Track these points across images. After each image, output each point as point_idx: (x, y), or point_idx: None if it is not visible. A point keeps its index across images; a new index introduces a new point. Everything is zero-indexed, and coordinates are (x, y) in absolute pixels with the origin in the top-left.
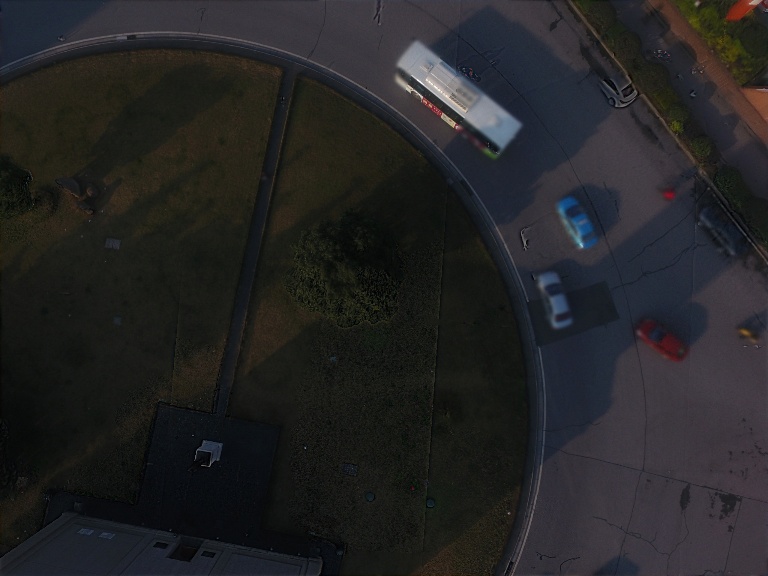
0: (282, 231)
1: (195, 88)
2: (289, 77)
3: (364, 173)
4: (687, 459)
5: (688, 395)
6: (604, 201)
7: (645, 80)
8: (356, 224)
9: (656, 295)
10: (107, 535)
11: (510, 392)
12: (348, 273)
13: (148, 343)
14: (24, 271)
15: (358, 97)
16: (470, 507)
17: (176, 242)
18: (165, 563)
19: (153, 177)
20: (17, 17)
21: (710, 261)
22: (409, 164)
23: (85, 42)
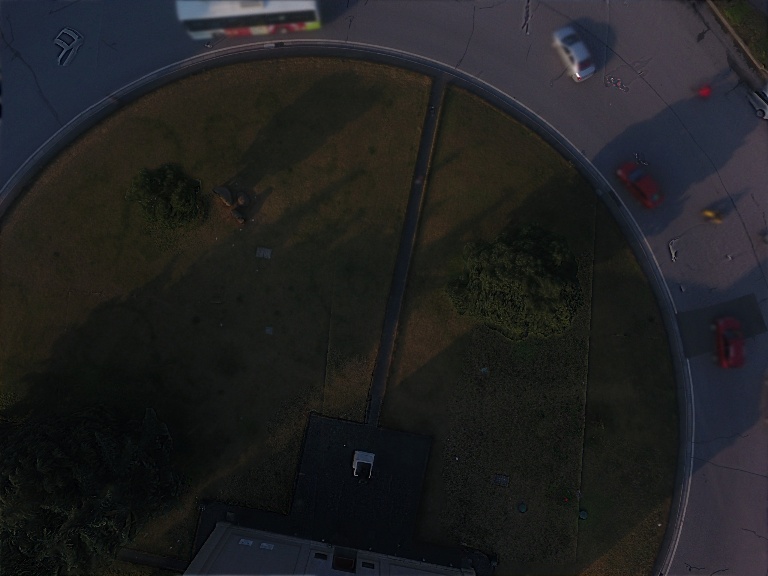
0: (433, 241)
1: (345, 97)
2: (438, 86)
3: (514, 183)
4: None
5: None
6: (752, 213)
7: None
8: (547, 238)
9: None
10: (267, 546)
11: (660, 404)
12: (554, 288)
13: (300, 353)
14: (175, 280)
15: (507, 107)
16: (622, 519)
17: (327, 252)
18: (334, 575)
19: (304, 186)
20: (163, 23)
21: None
22: (559, 175)
23: (233, 49)
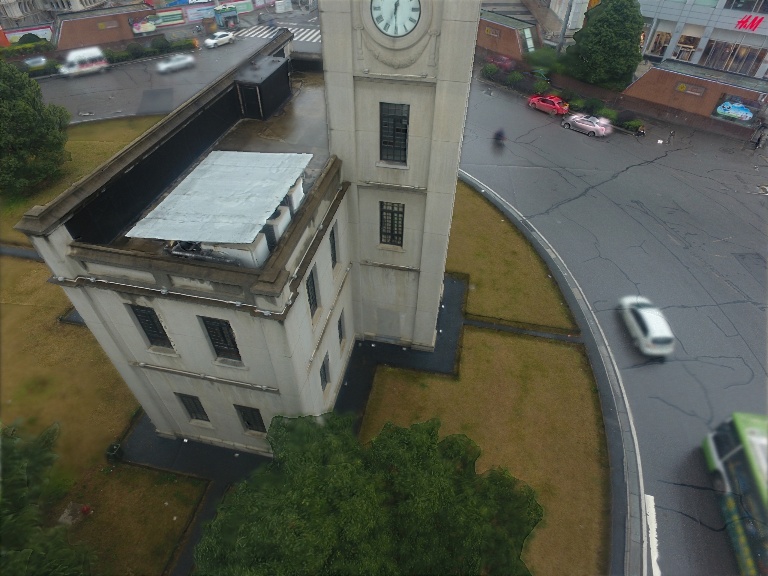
0: None
1: None
2: None
3: None
4: None
5: None
6: (88, 90)
7: None
8: None
9: None
10: None
11: None
12: None
13: None
14: None
15: None
16: None
17: None
18: None
19: None
20: None
21: None
22: None
23: None
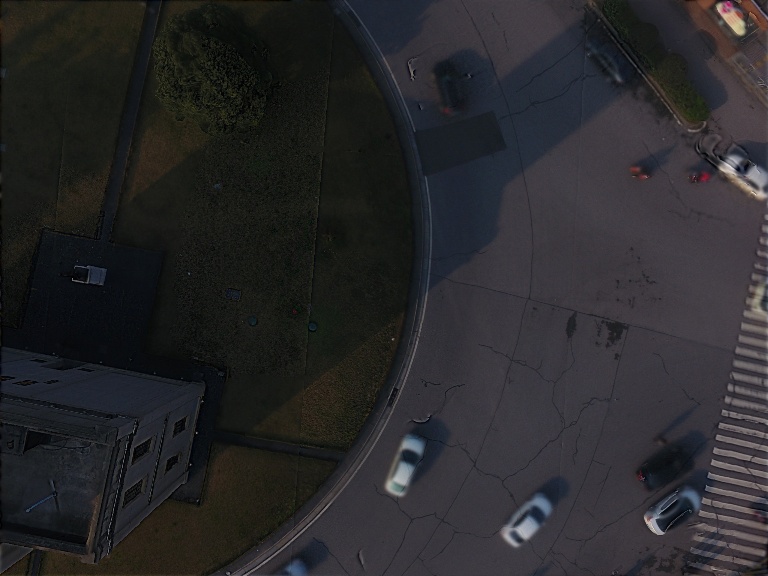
0: None
1: None
2: None
3: (250, 3)
4: (574, 287)
5: (576, 224)
6: (492, 32)
7: None
8: None
9: (544, 125)
10: None
11: (395, 220)
12: (190, 39)
13: (33, 170)
14: None
15: None
16: (353, 331)
17: (61, 70)
18: (36, 368)
19: (39, 6)
20: None
21: (599, 92)
22: None
23: None
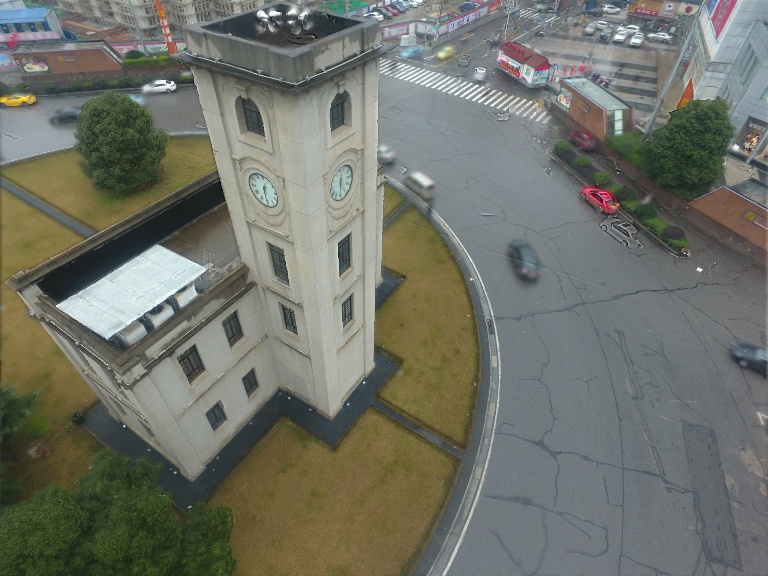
0: (71, 202)
1: None
2: None
3: None
4: None
5: None
6: None
7: (169, 77)
8: None
9: None
10: None
11: None
12: (108, 93)
13: None
14: None
15: None
16: None
17: None
18: None
19: None
20: None
21: None
22: None
23: None
